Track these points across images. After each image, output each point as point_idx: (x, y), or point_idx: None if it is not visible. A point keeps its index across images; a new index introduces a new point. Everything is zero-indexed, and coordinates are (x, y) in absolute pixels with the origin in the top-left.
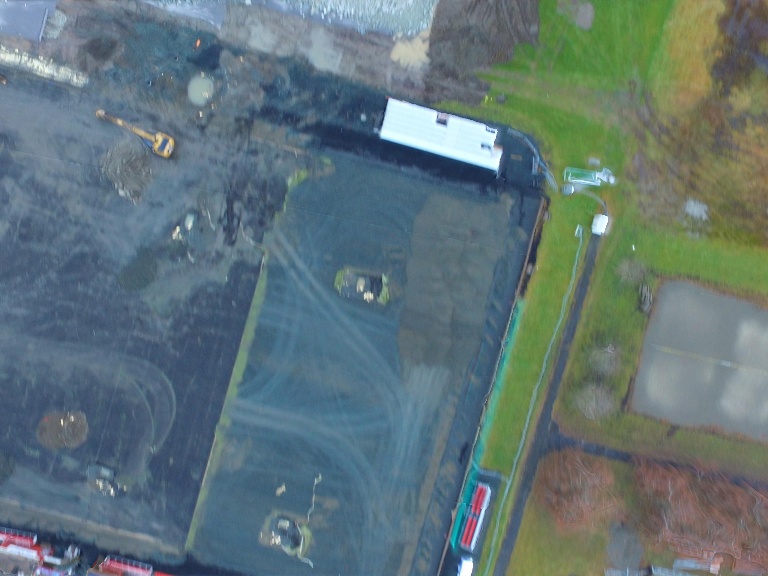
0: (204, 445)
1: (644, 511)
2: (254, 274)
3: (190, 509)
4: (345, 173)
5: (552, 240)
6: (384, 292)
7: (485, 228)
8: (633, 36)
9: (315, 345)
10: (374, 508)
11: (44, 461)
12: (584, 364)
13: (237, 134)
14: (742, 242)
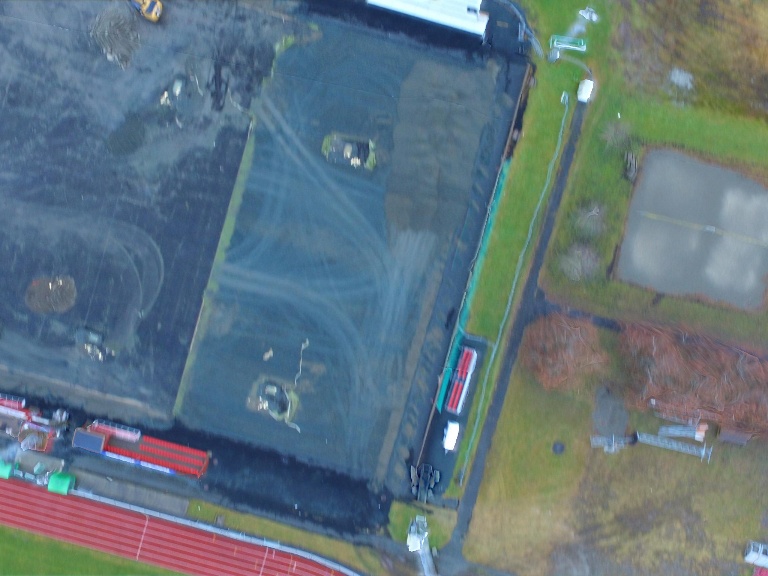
0: (192, 310)
1: (629, 372)
2: (242, 139)
3: (178, 374)
4: (332, 39)
5: (538, 107)
6: (371, 157)
7: (471, 92)
8: None
9: (302, 210)
10: (361, 373)
11: (33, 325)
12: (570, 231)
13: None
14: (727, 111)
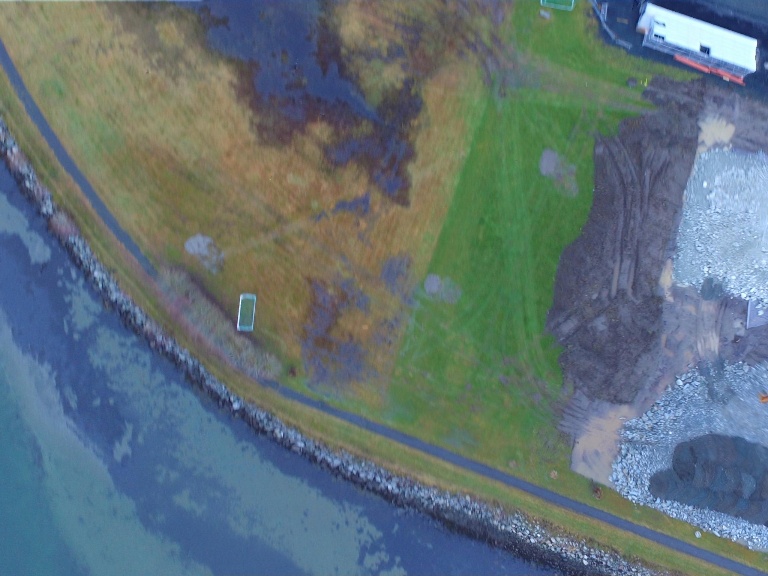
0: None
1: None
2: None
3: None
4: None
5: None
6: None
7: None
8: (502, 141)
9: None
10: None
11: None
12: None
13: None
14: None
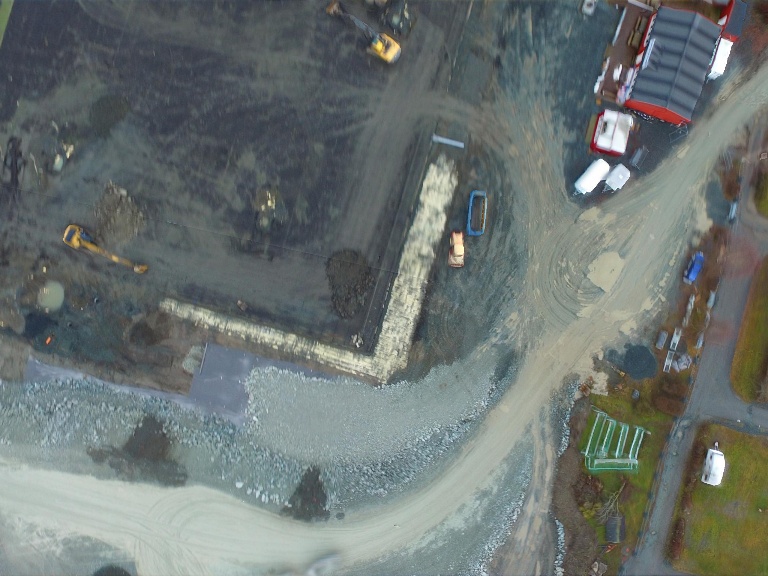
0: None
1: None
2: None
3: None
4: None
5: None
6: None
7: None
8: None
9: None
10: None
11: None
12: None
13: (8, 249)
14: None
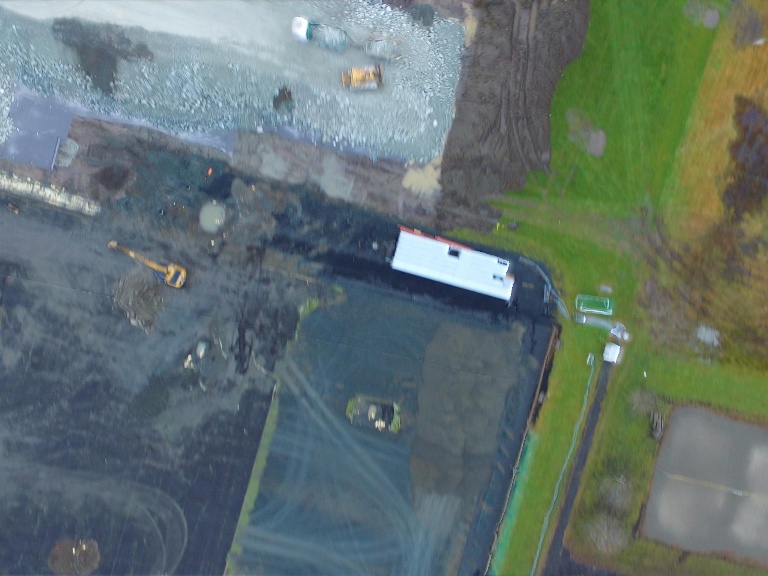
0: (215, 573)
1: None
2: (266, 402)
3: None
4: (357, 301)
5: (564, 368)
6: (396, 421)
7: (497, 359)
8: (645, 163)
9: (327, 473)
10: None
11: None
12: (595, 491)
13: (249, 263)
14: (754, 368)
